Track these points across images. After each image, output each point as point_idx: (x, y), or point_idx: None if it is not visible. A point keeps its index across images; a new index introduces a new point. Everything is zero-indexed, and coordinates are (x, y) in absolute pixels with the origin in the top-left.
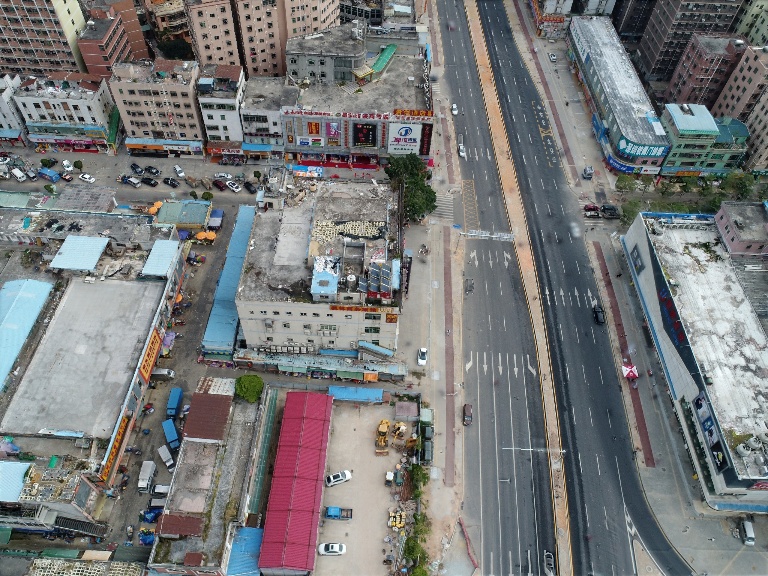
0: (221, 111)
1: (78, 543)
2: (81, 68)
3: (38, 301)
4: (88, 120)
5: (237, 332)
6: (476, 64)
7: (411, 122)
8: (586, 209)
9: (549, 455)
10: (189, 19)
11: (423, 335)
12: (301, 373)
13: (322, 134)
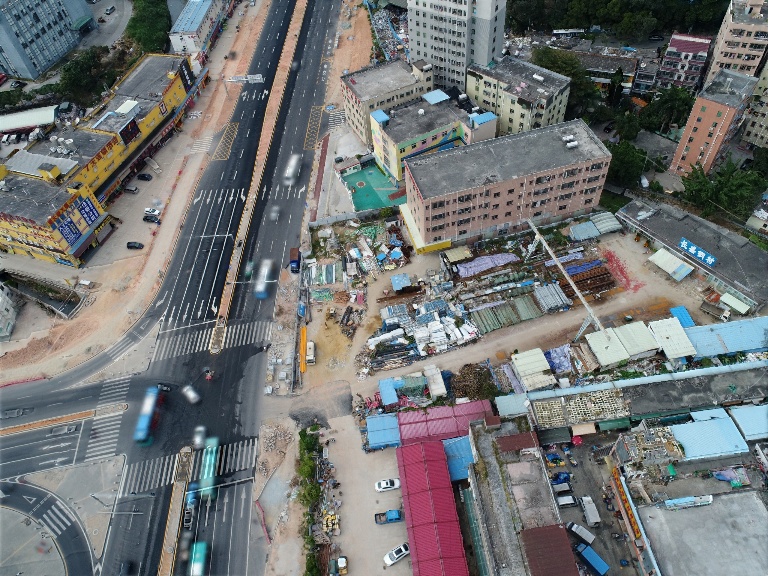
0: None
1: None
2: None
3: None
4: None
5: None
6: None
7: None
8: None
9: None
10: None
11: None
12: None
13: None
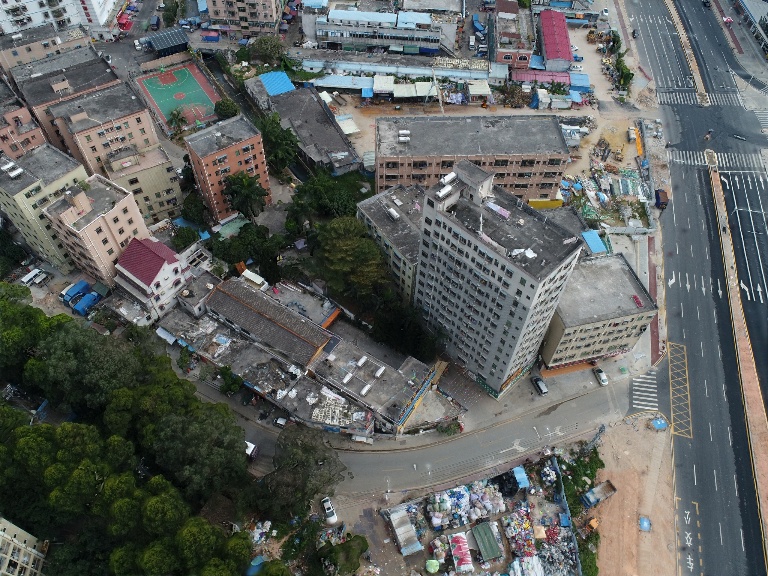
0: None
1: None
2: None
3: None
4: None
5: None
6: None
7: None
8: None
9: (684, 49)
10: None
11: (603, 6)
12: None
13: None
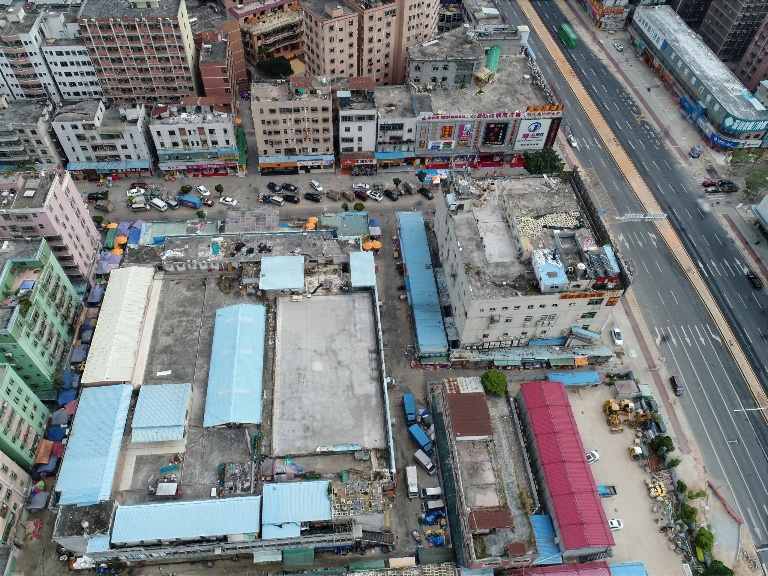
0: (359, 122)
1: (370, 554)
2: (196, 92)
3: (259, 324)
4: (221, 143)
5: (446, 333)
6: (552, 59)
7: (541, 117)
8: (705, 185)
9: (762, 413)
10: (314, 35)
11: None
12: (514, 366)
13: (454, 137)
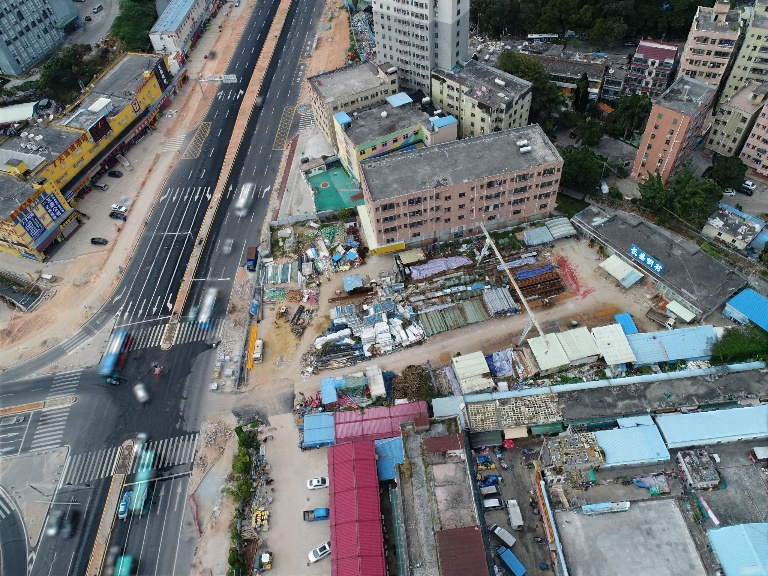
0: None
1: None
2: None
3: None
4: None
5: None
6: None
7: None
8: None
9: None
10: None
11: None
12: None
13: None
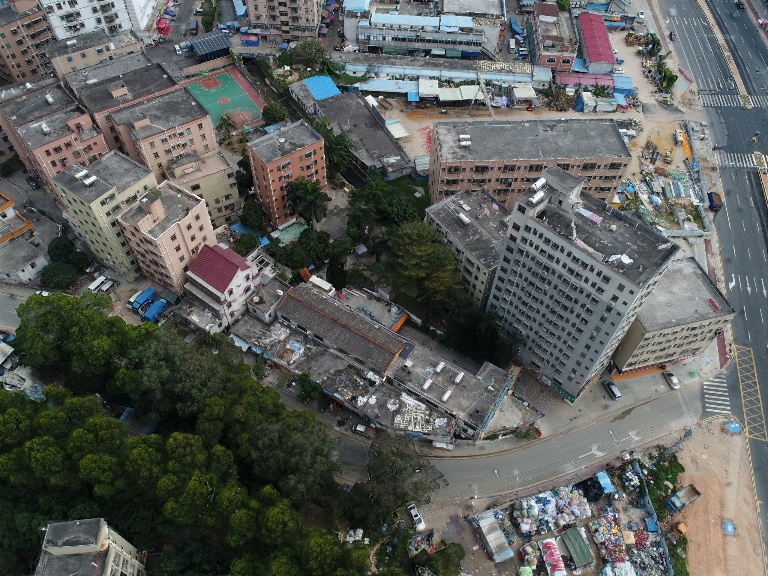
0: None
1: None
2: None
3: None
4: None
5: None
6: None
7: None
8: None
9: (722, 51)
10: None
11: (638, 9)
12: (576, 18)
13: None
